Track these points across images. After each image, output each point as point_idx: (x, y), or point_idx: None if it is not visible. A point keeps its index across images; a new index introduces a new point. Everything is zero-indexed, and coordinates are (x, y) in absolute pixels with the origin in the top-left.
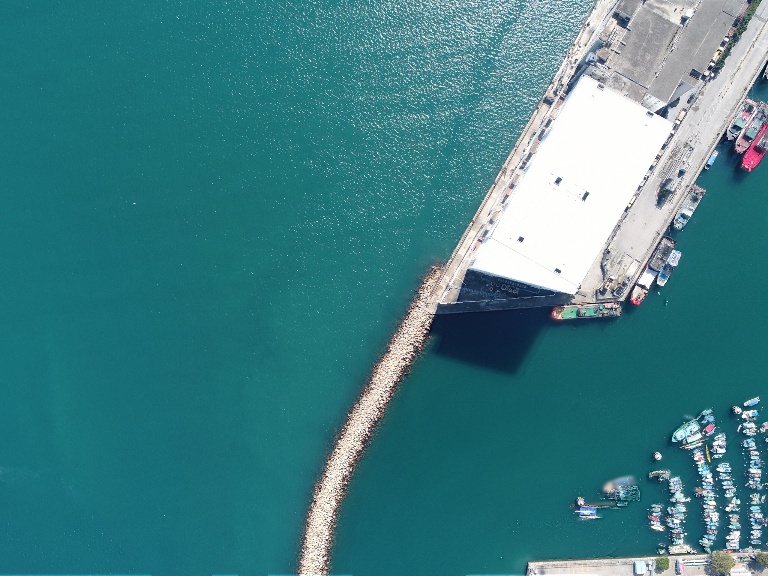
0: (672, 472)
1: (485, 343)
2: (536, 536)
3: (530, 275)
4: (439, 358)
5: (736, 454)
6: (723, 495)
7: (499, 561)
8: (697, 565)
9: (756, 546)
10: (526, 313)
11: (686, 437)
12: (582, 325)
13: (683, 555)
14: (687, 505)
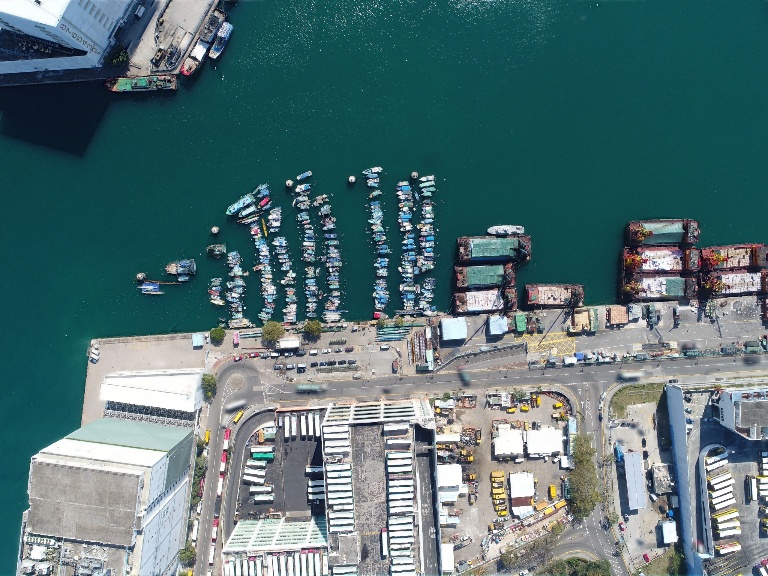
0: (230, 246)
1: (44, 117)
2: (104, 315)
3: (11, 6)
4: (1, 133)
5: (292, 228)
6: (280, 269)
7: (65, 339)
8: (253, 337)
9: (313, 319)
10: (84, 86)
11: (242, 211)
12: (141, 100)
13: (242, 329)
14: (246, 279)
